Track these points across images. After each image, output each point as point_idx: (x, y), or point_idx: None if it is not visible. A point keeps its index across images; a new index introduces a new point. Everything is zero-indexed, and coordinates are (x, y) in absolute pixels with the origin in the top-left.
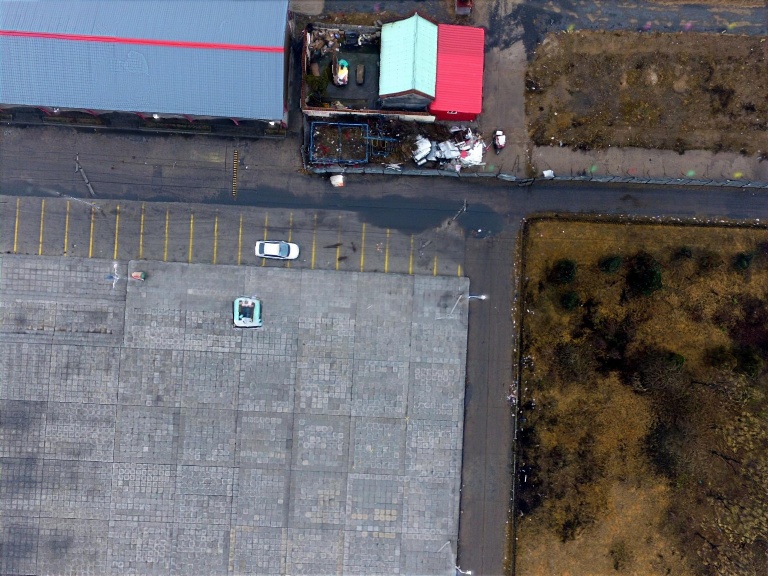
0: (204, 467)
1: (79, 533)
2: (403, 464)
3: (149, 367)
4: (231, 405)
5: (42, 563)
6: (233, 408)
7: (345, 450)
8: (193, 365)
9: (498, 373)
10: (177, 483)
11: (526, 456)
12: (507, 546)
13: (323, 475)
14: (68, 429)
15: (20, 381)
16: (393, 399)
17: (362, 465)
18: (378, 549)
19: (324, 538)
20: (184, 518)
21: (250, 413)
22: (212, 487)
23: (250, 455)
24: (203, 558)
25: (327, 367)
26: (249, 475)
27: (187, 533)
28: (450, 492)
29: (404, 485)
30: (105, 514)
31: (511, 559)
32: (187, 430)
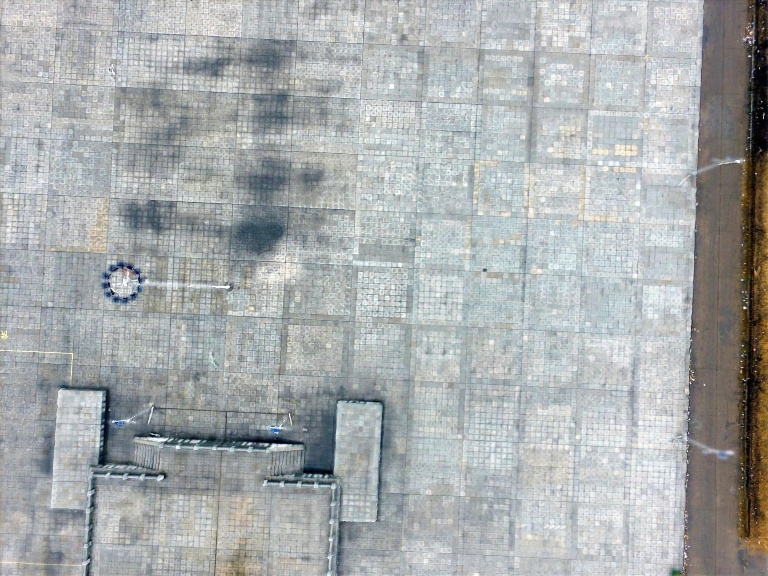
0: (448, 104)
1: (329, 166)
2: (643, 101)
3: (393, 7)
4: (473, 44)
5: (294, 195)
6: (475, 47)
7: (585, 87)
8: (436, 5)
9: (734, 15)
10: (422, 119)
11: (764, 93)
12: (745, 183)
13: (564, 112)
14: (317, 67)
15: (270, 21)
16: (632, 38)
17: (602, 102)
18: (619, 183)
19: (566, 172)
20: (429, 153)
21: (492, 52)
22: (456, 123)
23: (493, 92)
24: (448, 191)
25: (567, 7)
26: (492, 112)
27: (433, 167)
28: (689, 128)
29: (644, 121)
30: (354, 148)
31: (750, 194)
32: (431, 68)
